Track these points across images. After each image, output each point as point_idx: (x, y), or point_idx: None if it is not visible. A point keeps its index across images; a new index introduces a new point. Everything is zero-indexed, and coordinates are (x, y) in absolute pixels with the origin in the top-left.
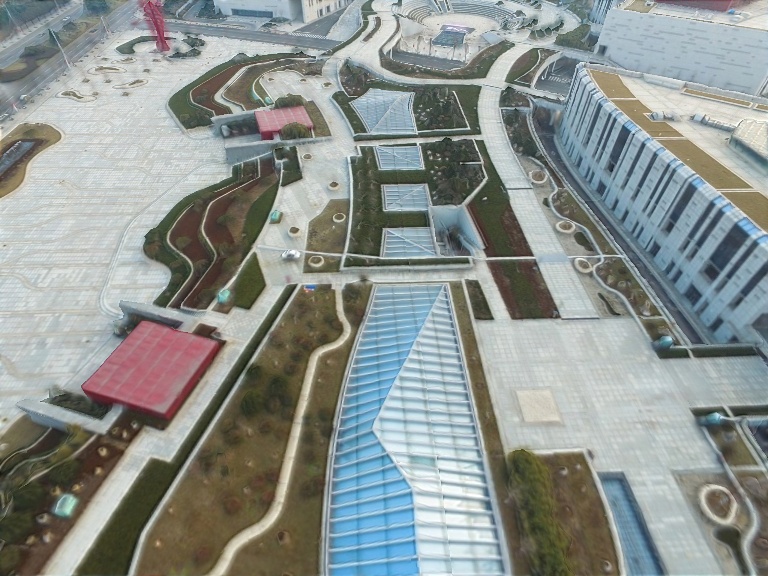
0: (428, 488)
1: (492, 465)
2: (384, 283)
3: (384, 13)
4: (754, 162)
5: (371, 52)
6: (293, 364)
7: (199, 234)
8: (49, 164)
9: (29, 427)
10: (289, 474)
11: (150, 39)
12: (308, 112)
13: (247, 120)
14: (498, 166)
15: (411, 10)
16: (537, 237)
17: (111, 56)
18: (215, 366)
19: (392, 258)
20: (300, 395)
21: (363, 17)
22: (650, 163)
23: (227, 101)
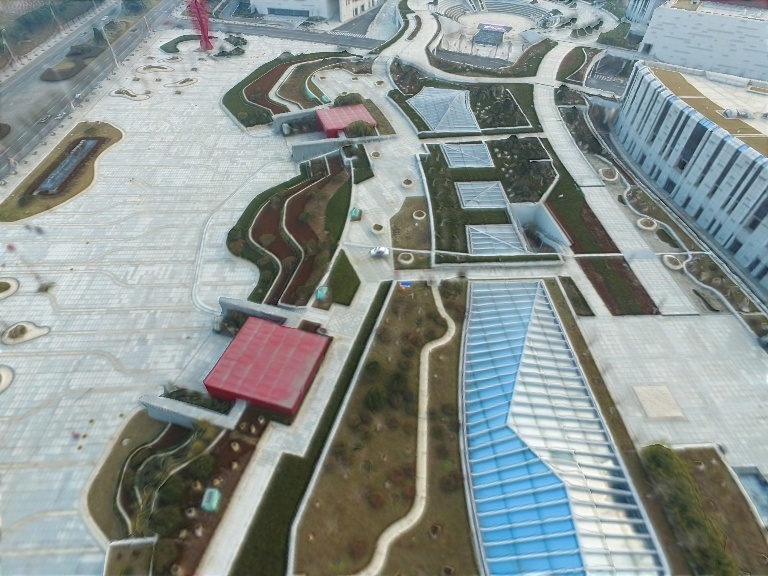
0: (576, 482)
1: (626, 460)
2: (479, 280)
3: (422, 12)
4: None
5: (418, 51)
6: (407, 360)
7: (281, 231)
8: (116, 162)
9: (147, 422)
10: (425, 469)
11: (192, 38)
12: (368, 110)
13: (307, 118)
14: (566, 164)
15: (446, 9)
16: (620, 234)
17: (156, 55)
18: (327, 362)
19: (482, 255)
20: (419, 391)
21: (402, 16)
22: (731, 160)
23: (282, 99)
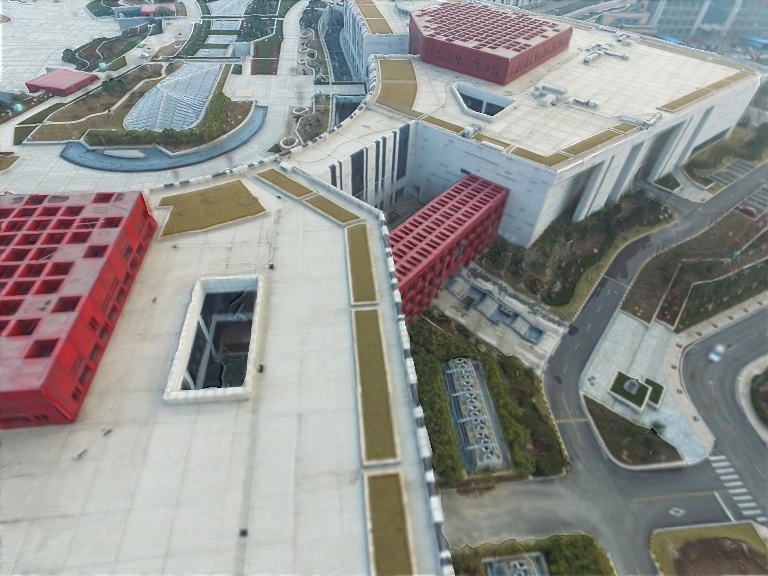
0: (173, 97)
1: None
2: None
3: None
4: (397, 11)
5: None
6: (131, 81)
7: (95, 52)
8: (3, 30)
9: None
10: (119, 104)
11: None
12: (176, 6)
13: (136, 11)
14: (285, 30)
15: None
16: (286, 53)
17: None
18: (93, 84)
19: None
20: (132, 89)
21: None
22: None
23: (126, 3)
